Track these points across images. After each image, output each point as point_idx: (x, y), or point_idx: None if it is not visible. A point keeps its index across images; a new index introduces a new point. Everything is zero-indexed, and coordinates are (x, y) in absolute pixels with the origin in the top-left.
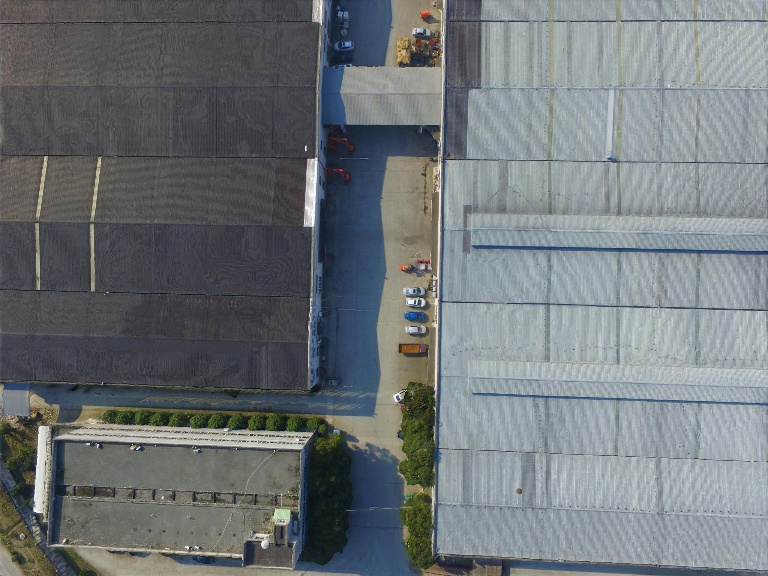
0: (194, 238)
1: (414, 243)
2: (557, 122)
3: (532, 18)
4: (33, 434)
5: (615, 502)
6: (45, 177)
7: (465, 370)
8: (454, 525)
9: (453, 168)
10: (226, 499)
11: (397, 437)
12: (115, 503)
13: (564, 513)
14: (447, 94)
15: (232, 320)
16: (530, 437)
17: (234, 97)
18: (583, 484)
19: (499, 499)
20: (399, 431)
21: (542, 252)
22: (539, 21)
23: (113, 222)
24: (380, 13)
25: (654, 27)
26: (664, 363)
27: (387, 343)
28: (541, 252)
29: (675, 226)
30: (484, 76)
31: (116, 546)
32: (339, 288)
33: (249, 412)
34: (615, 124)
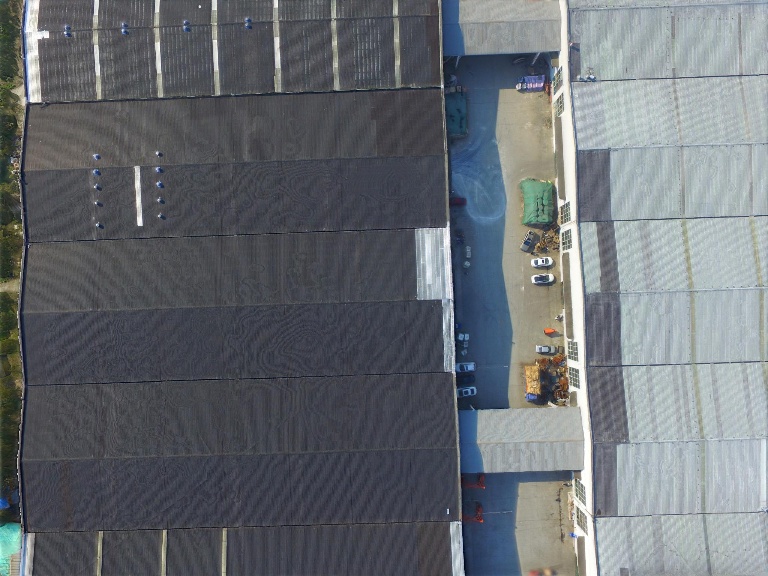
0: None
1: (553, 574)
2: (709, 474)
3: (674, 362)
4: None
5: None
6: (166, 555)
7: None
8: None
9: (605, 526)
10: None
11: None
12: None
13: None
14: (594, 450)
15: None
16: None
17: (368, 461)
18: None
19: None
20: None
21: None
22: (681, 364)
23: None
24: (500, 328)
25: None
26: None
27: None
28: None
29: None
30: (631, 429)
31: None
32: None
33: None
34: None
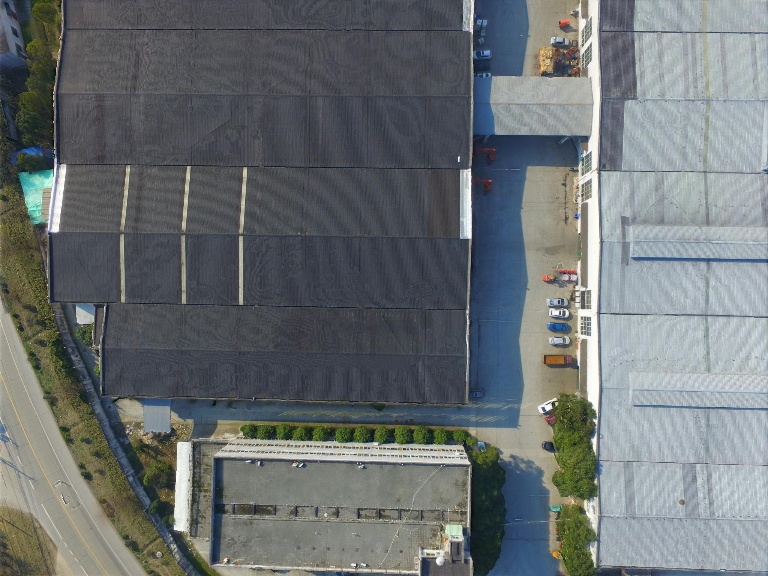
0: (347, 250)
1: (555, 253)
2: (713, 134)
3: (685, 29)
4: (167, 450)
5: None
6: (189, 188)
7: (626, 382)
8: (617, 537)
9: (609, 179)
10: (391, 515)
11: (542, 448)
12: (277, 521)
13: (727, 523)
14: (603, 105)
15: (387, 333)
16: (691, 448)
17: (385, 107)
18: (745, 494)
19: (662, 510)
20: (545, 442)
21: (701, 264)
22: (692, 32)
23: (263, 234)
24: (517, 21)
25: None
26: None
27: (530, 354)
28: (700, 264)
29: None
30: (640, 87)
31: (280, 565)
32: (480, 299)
33: (390, 425)
34: None
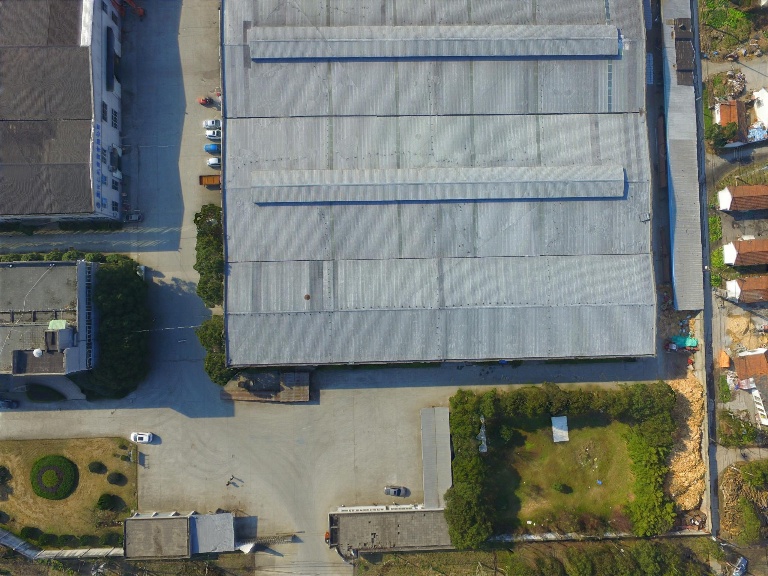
0: None
1: (213, 77)
2: None
3: None
4: None
5: (399, 301)
6: None
7: (249, 182)
8: (245, 335)
9: None
10: (4, 319)
11: None
12: None
13: (351, 315)
14: None
15: (11, 145)
16: (317, 245)
17: None
18: (369, 287)
19: (287, 306)
20: None
21: (322, 64)
22: None
23: None
24: None
25: None
26: (441, 166)
27: (190, 177)
28: (321, 64)
29: (445, 33)
30: None
31: None
32: (139, 125)
33: None
34: None
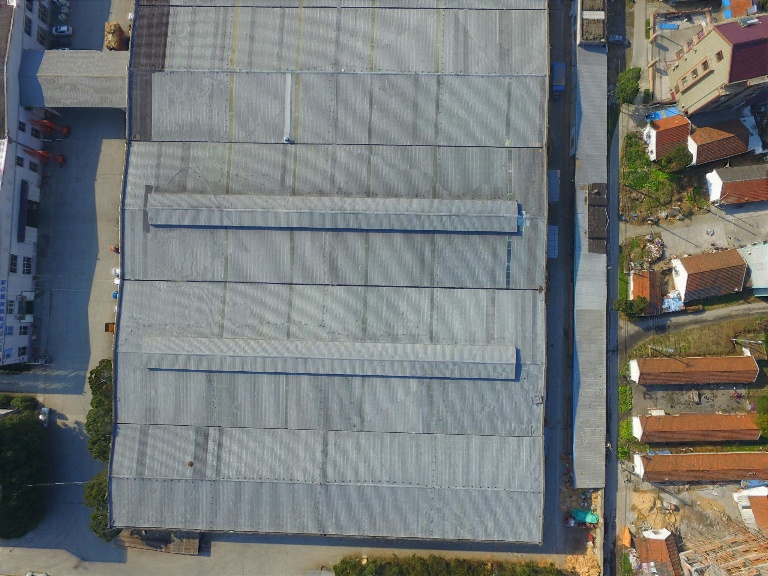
0: None
1: None
2: (237, 105)
3: (218, 3)
4: None
5: (281, 473)
6: None
7: (141, 346)
8: (128, 498)
9: (138, 149)
10: None
11: None
12: None
13: (232, 485)
14: (132, 77)
15: None
16: (204, 411)
17: None
18: (252, 456)
19: (171, 472)
20: None
21: (218, 231)
22: (225, 6)
23: None
24: None
25: (334, 13)
26: (331, 338)
27: (97, 322)
28: (218, 231)
29: (341, 206)
30: (168, 59)
31: None
32: (53, 269)
33: None
34: (292, 107)
